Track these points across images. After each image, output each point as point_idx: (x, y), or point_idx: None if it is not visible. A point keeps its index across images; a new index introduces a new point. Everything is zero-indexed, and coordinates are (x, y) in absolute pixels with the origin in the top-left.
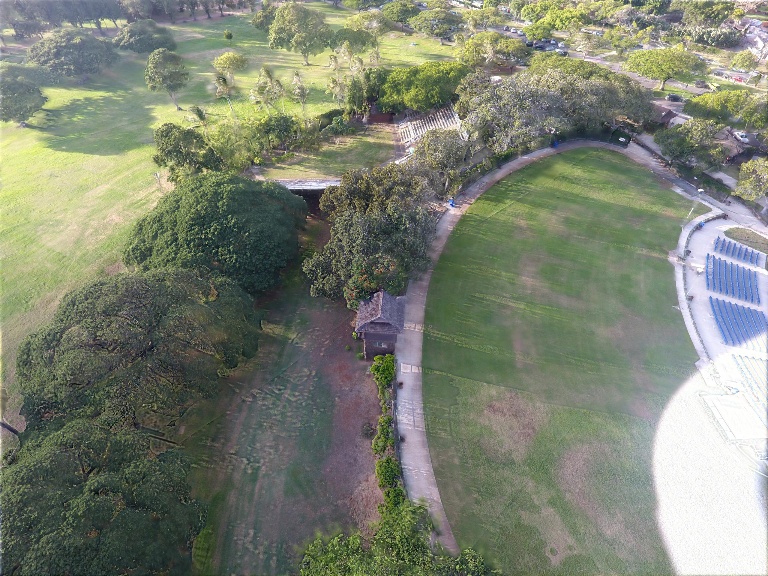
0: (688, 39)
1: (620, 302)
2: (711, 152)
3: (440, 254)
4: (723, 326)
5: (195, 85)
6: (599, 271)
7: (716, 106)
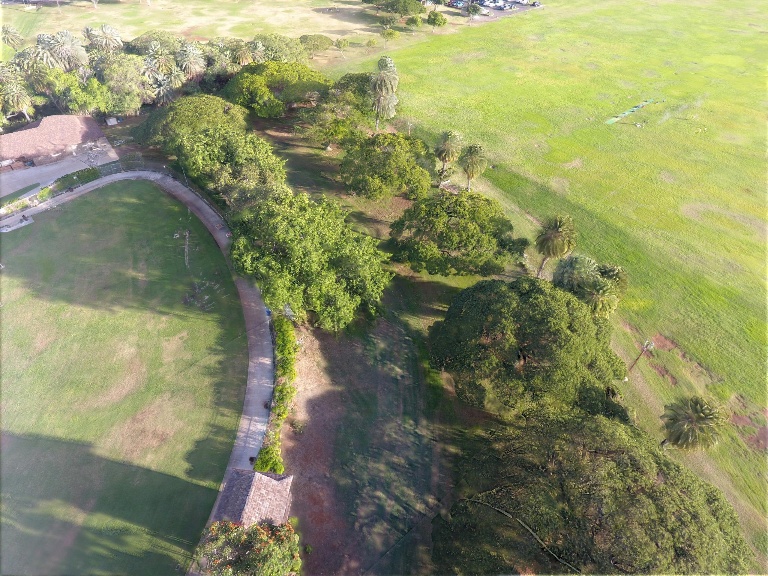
0: None
1: None
2: None
3: None
4: None
5: None
6: None
7: None
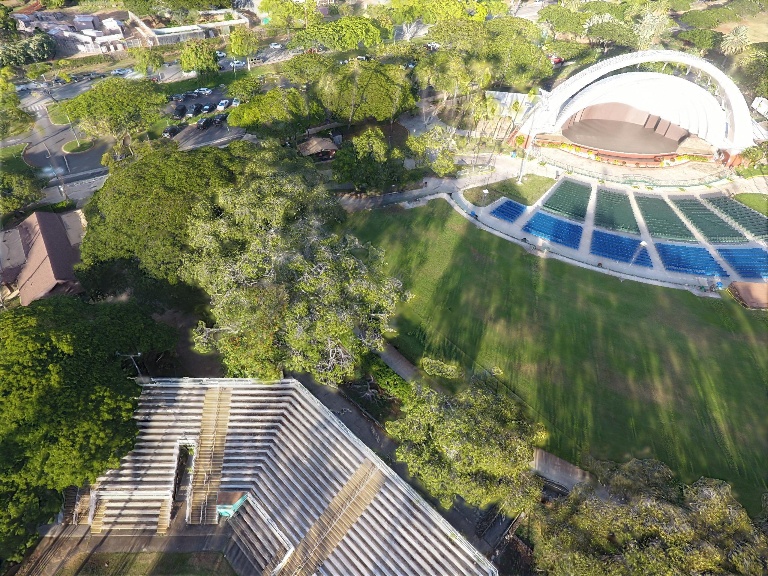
0: (65, 64)
1: (642, 319)
2: (397, 157)
3: None
4: None
5: None
6: (597, 319)
7: None
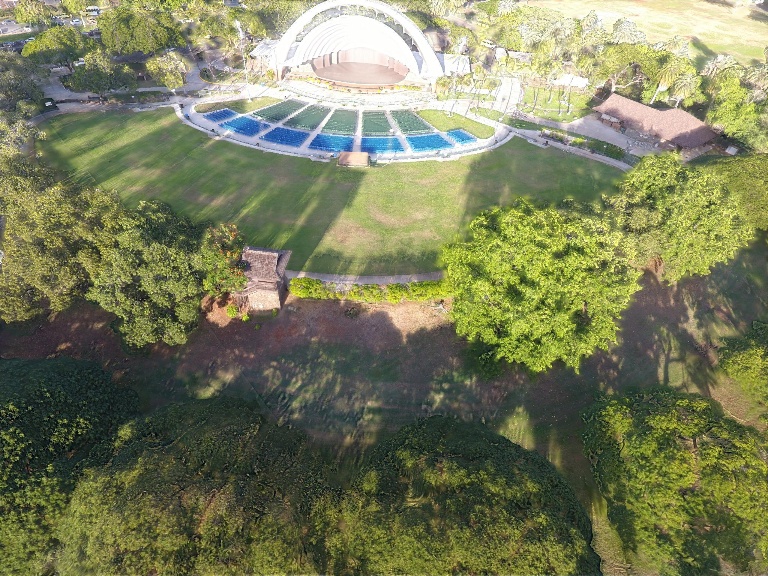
0: None
1: (254, 170)
2: (125, 71)
3: None
4: (286, 142)
5: None
6: (218, 169)
7: (59, 46)
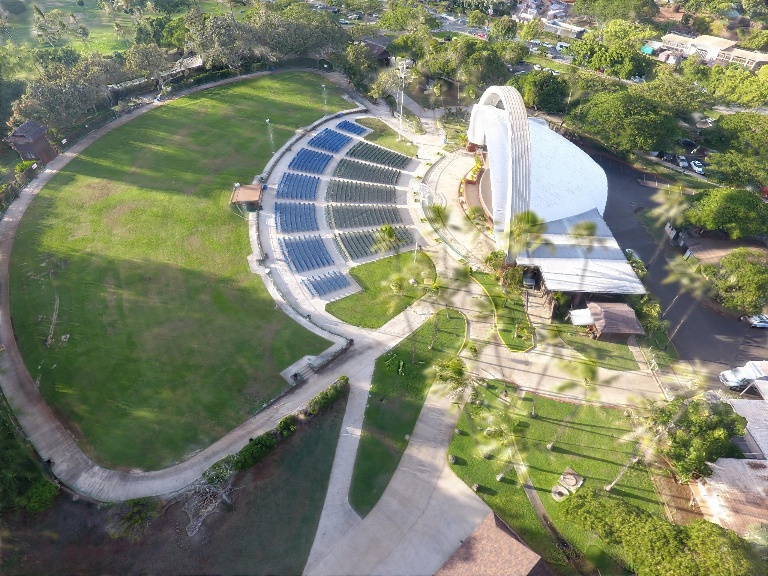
0: (444, 4)
1: (234, 149)
2: (361, 67)
3: (124, 123)
4: (295, 161)
5: (33, 37)
6: (235, 135)
7: (400, 42)
